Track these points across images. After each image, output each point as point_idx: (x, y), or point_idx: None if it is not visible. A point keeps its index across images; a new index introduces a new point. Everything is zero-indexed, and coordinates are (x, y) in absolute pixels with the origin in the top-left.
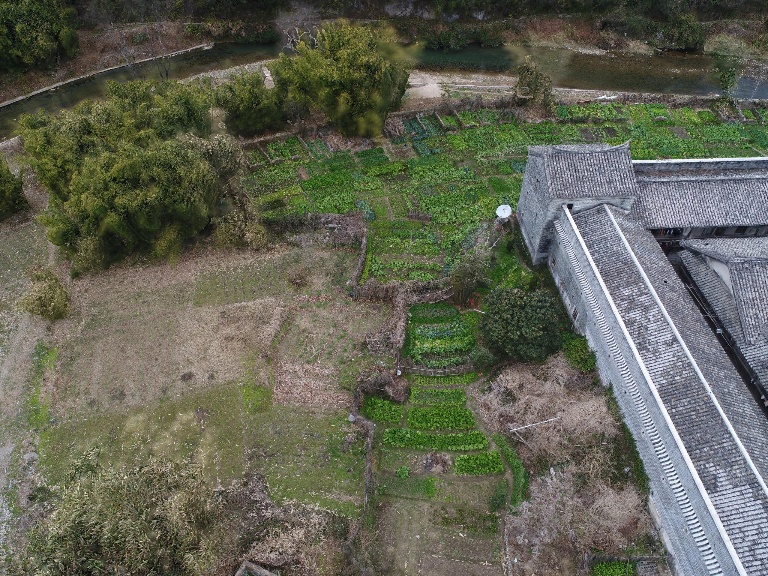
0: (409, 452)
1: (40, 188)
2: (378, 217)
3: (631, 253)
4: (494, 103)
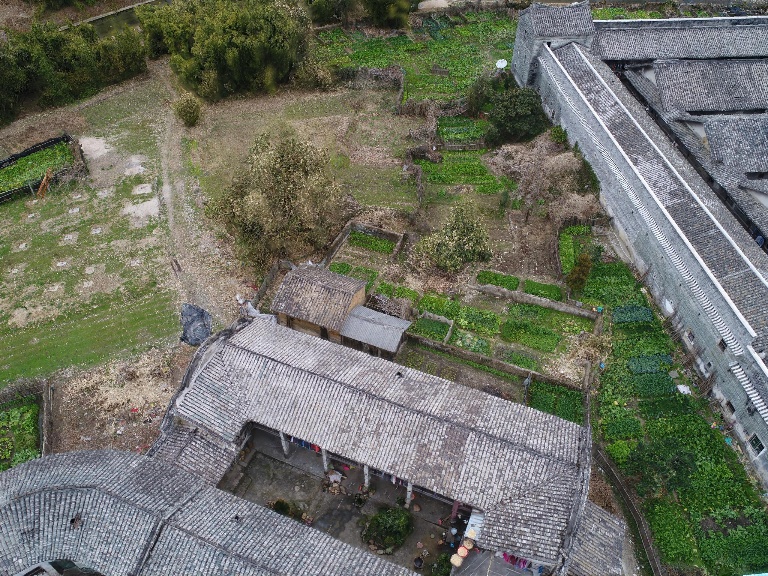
0: (445, 185)
1: (150, 62)
2: (409, 73)
3: (590, 65)
4: (491, 6)
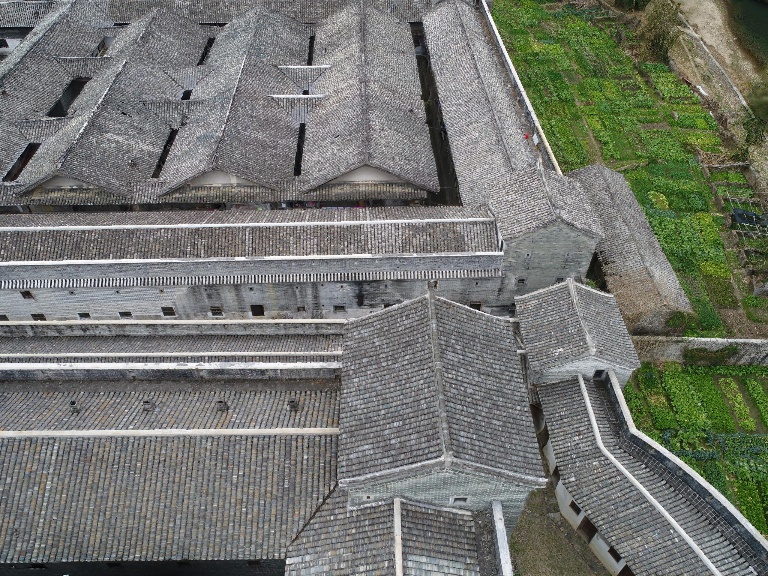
0: None
1: None
2: None
3: None
4: None
